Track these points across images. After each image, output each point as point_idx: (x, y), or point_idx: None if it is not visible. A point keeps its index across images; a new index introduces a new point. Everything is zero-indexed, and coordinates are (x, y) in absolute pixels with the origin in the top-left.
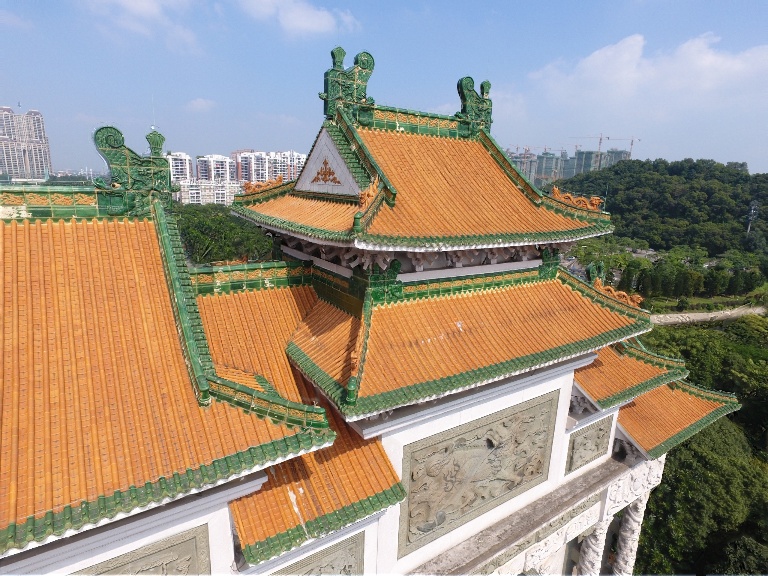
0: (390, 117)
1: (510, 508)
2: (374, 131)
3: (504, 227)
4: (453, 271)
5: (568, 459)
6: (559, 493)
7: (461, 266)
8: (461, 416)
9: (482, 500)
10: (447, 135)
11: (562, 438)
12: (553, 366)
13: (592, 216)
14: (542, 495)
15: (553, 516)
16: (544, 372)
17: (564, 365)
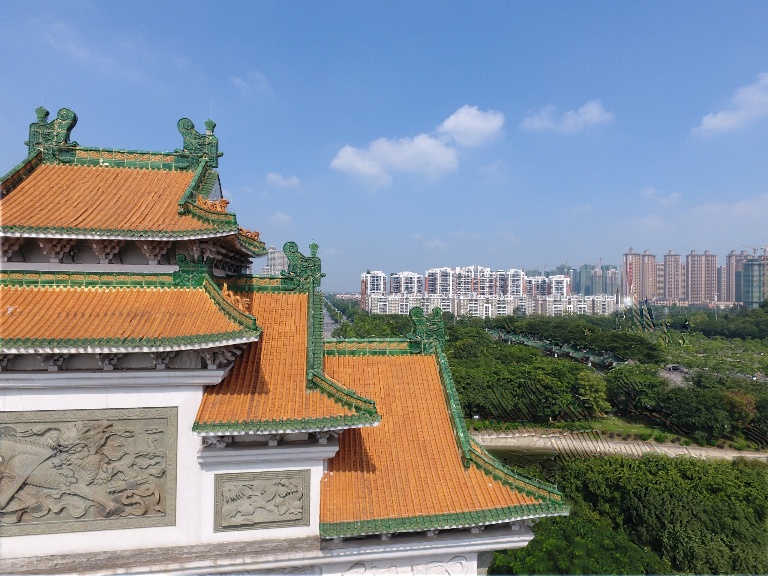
0: (94, 155)
1: (105, 542)
2: (75, 166)
3: (89, 224)
4: (44, 265)
5: (219, 509)
6: (191, 549)
7: (57, 262)
8: (6, 401)
9: (55, 515)
10: (161, 167)
11: (196, 474)
12: (138, 371)
13: (221, 218)
14: (168, 545)
15: (140, 565)
16: (116, 373)
17: (154, 372)
